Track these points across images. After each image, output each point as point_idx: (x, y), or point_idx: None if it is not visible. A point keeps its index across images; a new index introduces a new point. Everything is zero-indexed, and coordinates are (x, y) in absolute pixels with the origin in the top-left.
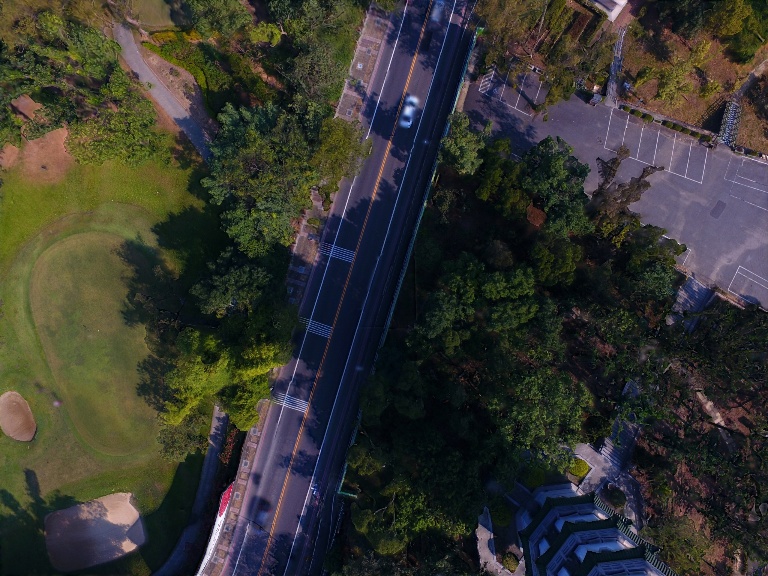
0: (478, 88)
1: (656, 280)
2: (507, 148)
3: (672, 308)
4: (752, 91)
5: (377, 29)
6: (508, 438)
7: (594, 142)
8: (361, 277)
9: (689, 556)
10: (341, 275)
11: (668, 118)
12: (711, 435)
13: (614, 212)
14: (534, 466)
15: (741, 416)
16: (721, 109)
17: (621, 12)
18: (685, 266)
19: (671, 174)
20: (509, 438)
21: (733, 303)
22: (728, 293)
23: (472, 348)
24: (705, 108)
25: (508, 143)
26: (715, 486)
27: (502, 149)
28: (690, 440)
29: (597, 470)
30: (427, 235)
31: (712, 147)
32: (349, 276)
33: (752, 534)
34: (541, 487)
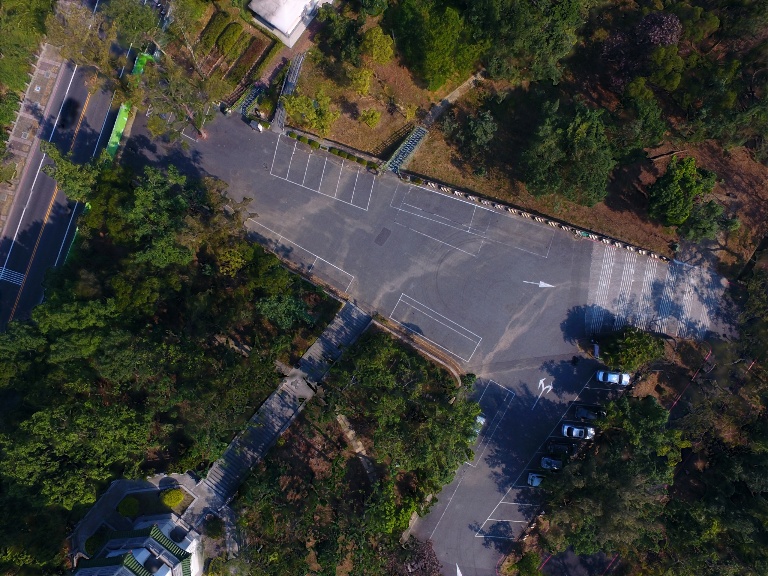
0: (146, 113)
1: (272, 310)
2: (114, 177)
3: (324, 336)
4: (444, 117)
5: (57, 52)
6: (4, 474)
7: (260, 168)
8: (30, 300)
9: None
10: (10, 298)
11: (336, 145)
12: (350, 464)
13: (217, 242)
14: (34, 502)
15: None
16: (408, 135)
17: (300, 38)
18: (348, 293)
19: (336, 201)
20: (6, 474)
21: (389, 331)
22: (389, 321)
23: (31, 379)
24: (389, 134)
25: (119, 171)
26: (354, 515)
27: (109, 178)
28: (271, 473)
29: (200, 500)
30: (78, 260)
31: (378, 174)
32: (18, 299)
33: None
34: (141, 517)
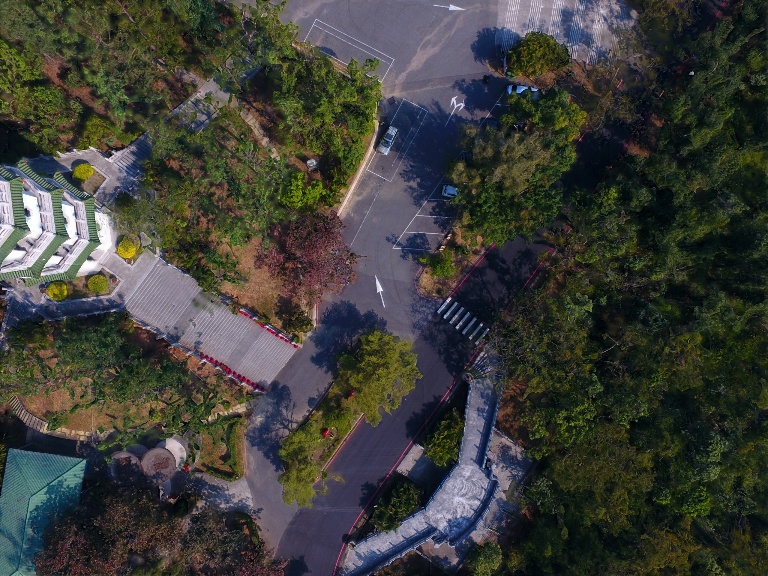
0: None
1: None
2: None
3: None
4: None
5: None
6: None
7: None
8: None
9: (155, 234)
10: None
11: None
12: None
13: None
14: None
15: (298, 152)
16: None
17: None
18: None
19: None
20: None
21: None
22: None
23: None
24: None
25: None
26: None
27: None
28: None
29: (112, 180)
30: None
31: None
32: None
33: (177, 188)
34: None
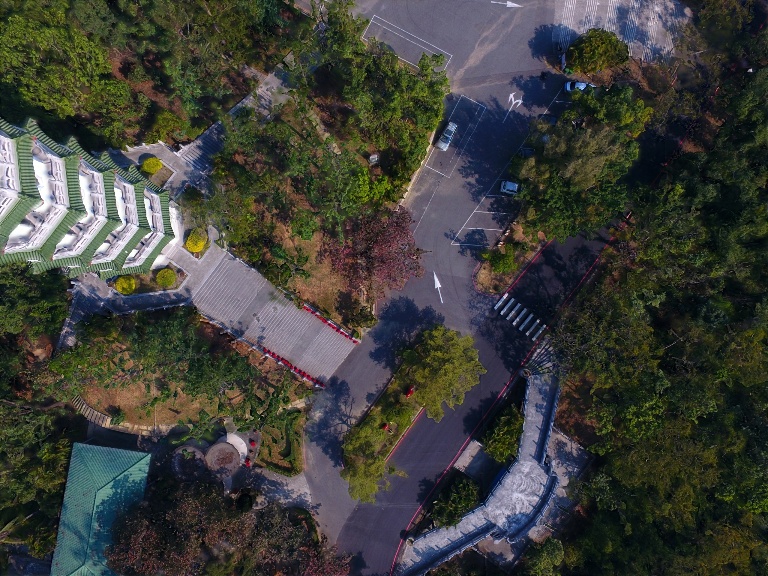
0: None
1: None
2: None
3: None
4: None
5: None
6: None
7: None
8: None
9: (229, 227)
10: None
11: None
12: None
13: None
14: None
15: None
16: None
17: None
18: None
19: None
20: None
21: None
22: (362, 41)
23: None
24: None
25: None
26: None
27: None
28: None
29: (179, 174)
30: None
31: None
32: None
33: None
34: None
